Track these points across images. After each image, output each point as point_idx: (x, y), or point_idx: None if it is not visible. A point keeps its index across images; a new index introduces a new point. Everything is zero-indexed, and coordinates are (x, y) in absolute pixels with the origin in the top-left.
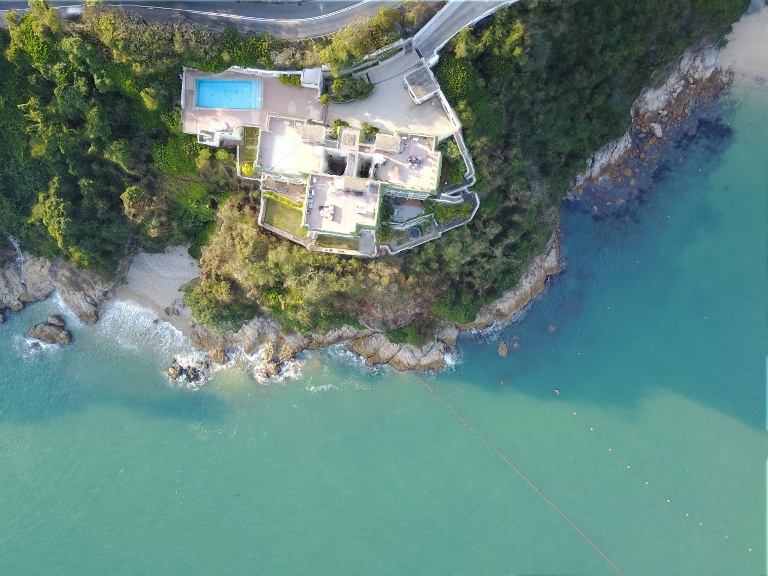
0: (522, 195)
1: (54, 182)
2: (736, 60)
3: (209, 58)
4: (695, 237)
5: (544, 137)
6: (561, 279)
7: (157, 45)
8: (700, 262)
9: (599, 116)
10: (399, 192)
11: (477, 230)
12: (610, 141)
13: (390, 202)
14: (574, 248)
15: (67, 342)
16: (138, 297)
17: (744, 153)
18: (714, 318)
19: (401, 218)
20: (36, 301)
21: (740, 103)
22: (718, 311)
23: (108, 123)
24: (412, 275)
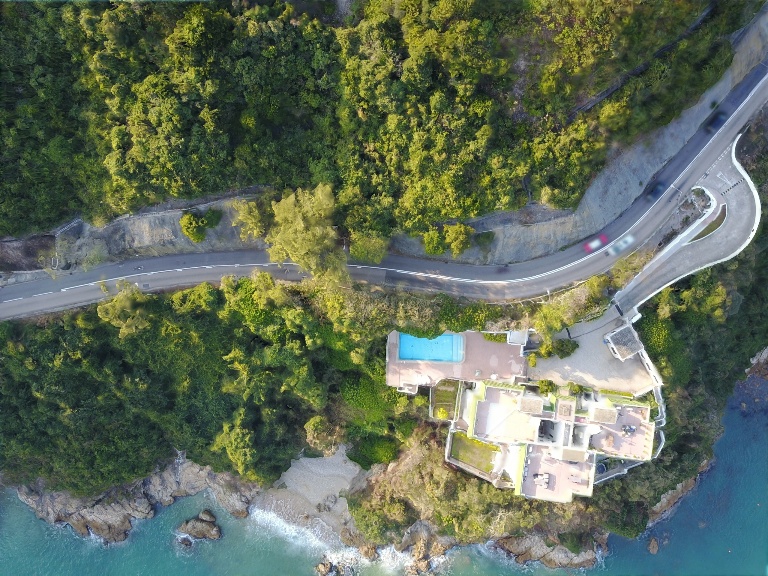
0: (701, 425)
1: (240, 413)
2: None
3: (427, 328)
4: None
5: (716, 361)
6: (710, 475)
7: (380, 320)
8: None
9: (761, 330)
10: None
11: None
12: None
13: None
14: (722, 443)
15: (217, 537)
16: (289, 493)
17: None
18: None
19: None
20: (187, 495)
21: None
22: None
23: None
24: (593, 506)
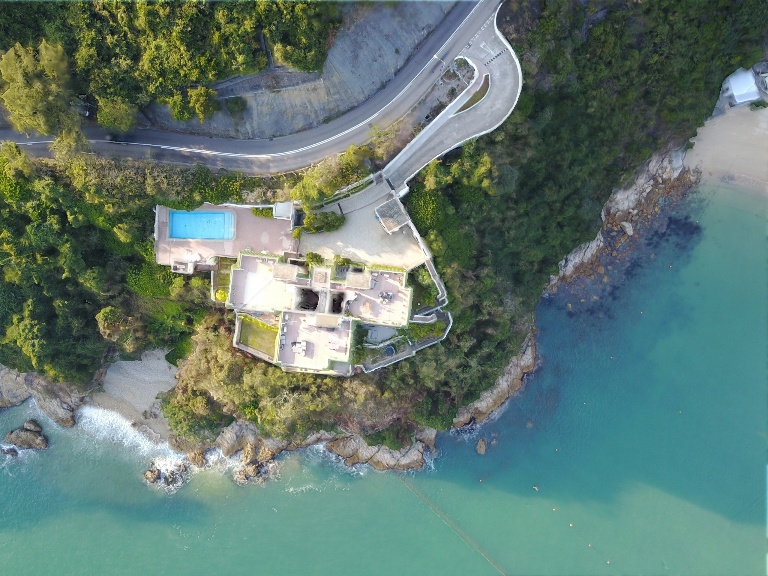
0: (495, 310)
1: (28, 305)
2: (703, 159)
3: (181, 198)
4: (668, 332)
5: (516, 249)
6: (537, 376)
7: (129, 188)
8: (674, 356)
9: (570, 223)
10: None
11: (451, 344)
12: (582, 243)
13: (363, 328)
14: (550, 344)
15: (43, 447)
16: (115, 401)
17: (713, 249)
18: (689, 412)
19: (375, 340)
20: (12, 406)
21: (708, 200)
22: (692, 405)
23: (82, 250)
24: (387, 391)
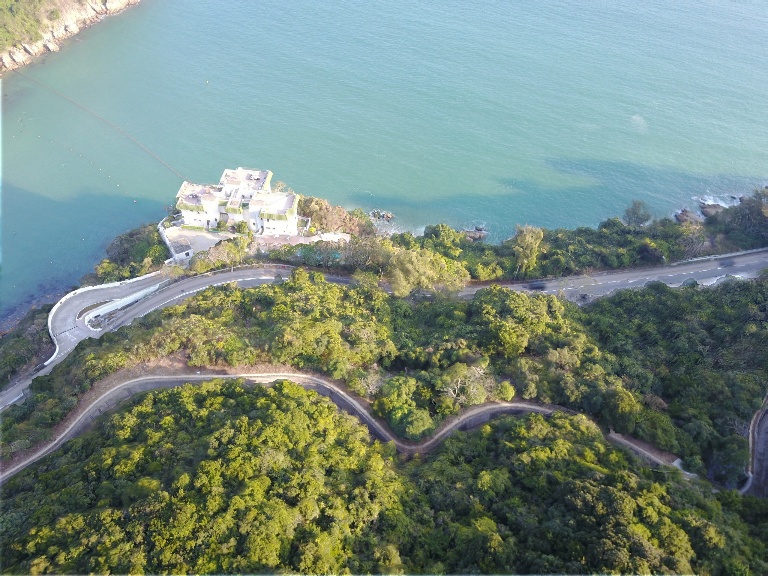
0: None
1: None
2: None
3: None
4: None
5: None
6: None
7: None
8: (2, 264)
9: None
10: None
11: None
12: None
13: None
14: None
15: None
16: None
17: None
18: (8, 233)
19: None
20: None
21: None
22: (3, 237)
23: None
24: None
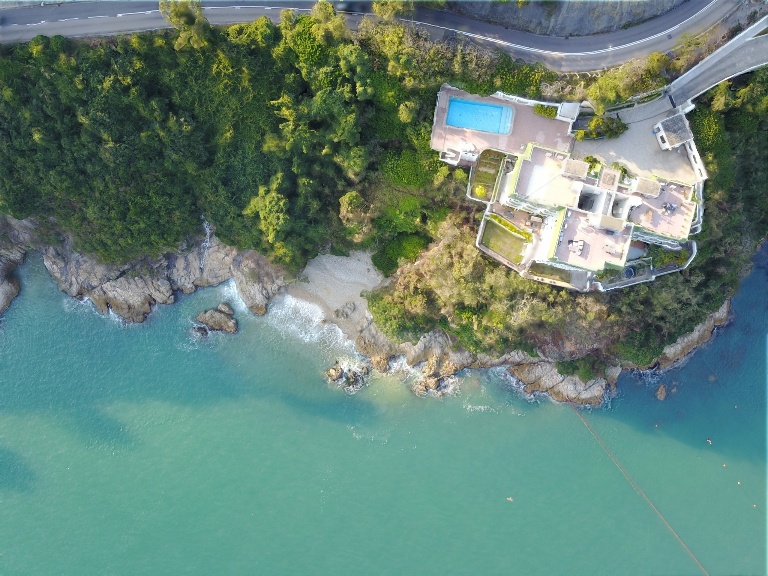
0: (733, 248)
1: (277, 178)
2: None
3: (481, 81)
4: None
5: (756, 193)
6: (727, 331)
7: (437, 63)
8: None
9: None
10: (642, 235)
11: None
12: None
13: None
14: (743, 302)
15: (233, 331)
16: (309, 295)
17: None
18: None
19: None
20: (208, 286)
21: None
22: None
23: None
24: (615, 313)
